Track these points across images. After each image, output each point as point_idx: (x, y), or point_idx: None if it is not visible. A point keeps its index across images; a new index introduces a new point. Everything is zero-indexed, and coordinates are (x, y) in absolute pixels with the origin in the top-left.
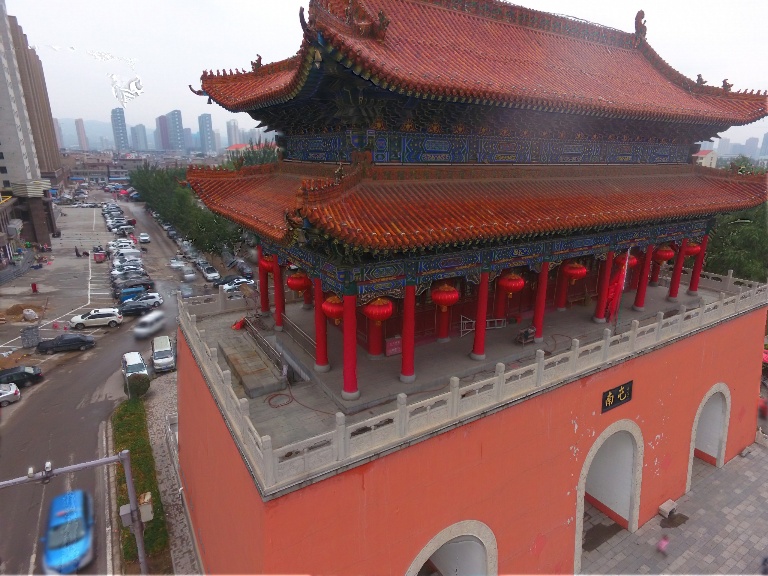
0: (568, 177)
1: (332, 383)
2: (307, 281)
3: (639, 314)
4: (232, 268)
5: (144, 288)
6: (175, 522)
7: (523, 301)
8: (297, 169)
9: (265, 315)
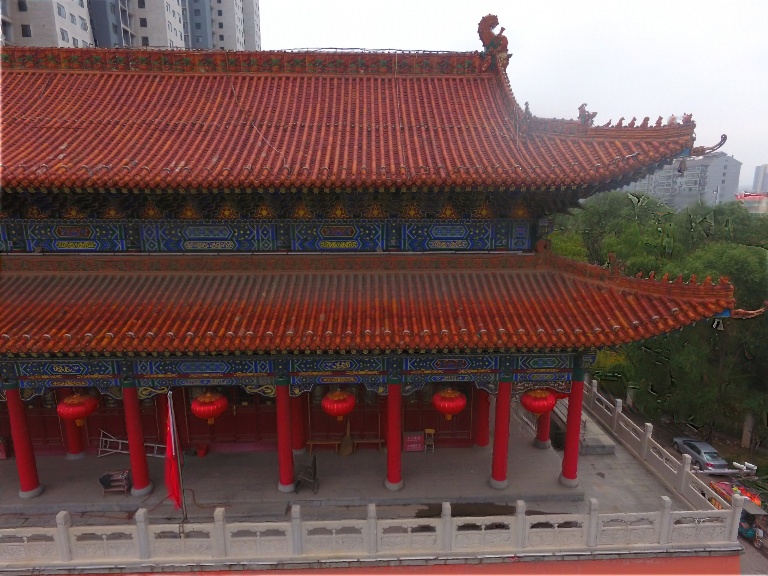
0: (195, 271)
1: None
2: None
3: (382, 493)
4: None
5: None
6: None
7: (220, 427)
8: None
9: None
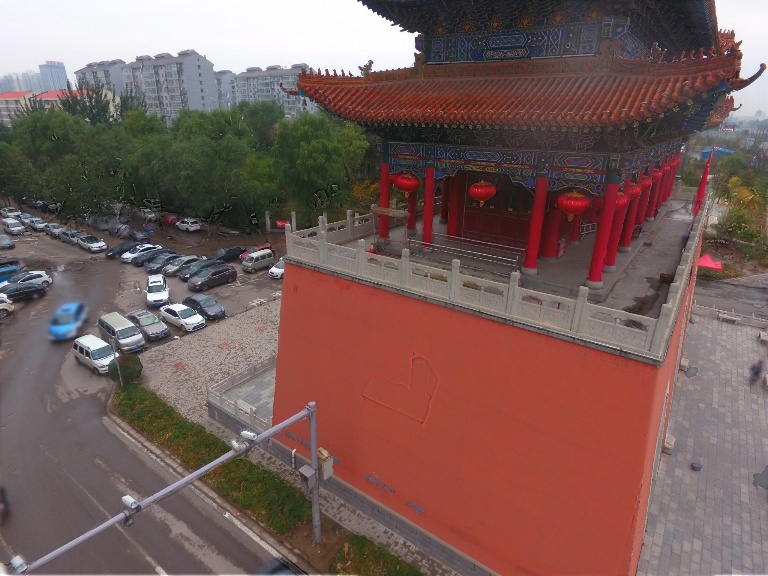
0: None
1: (558, 281)
2: (495, 189)
3: (660, 214)
4: (120, 234)
5: (17, 267)
6: (301, 486)
7: None
8: (466, 70)
9: (387, 242)
